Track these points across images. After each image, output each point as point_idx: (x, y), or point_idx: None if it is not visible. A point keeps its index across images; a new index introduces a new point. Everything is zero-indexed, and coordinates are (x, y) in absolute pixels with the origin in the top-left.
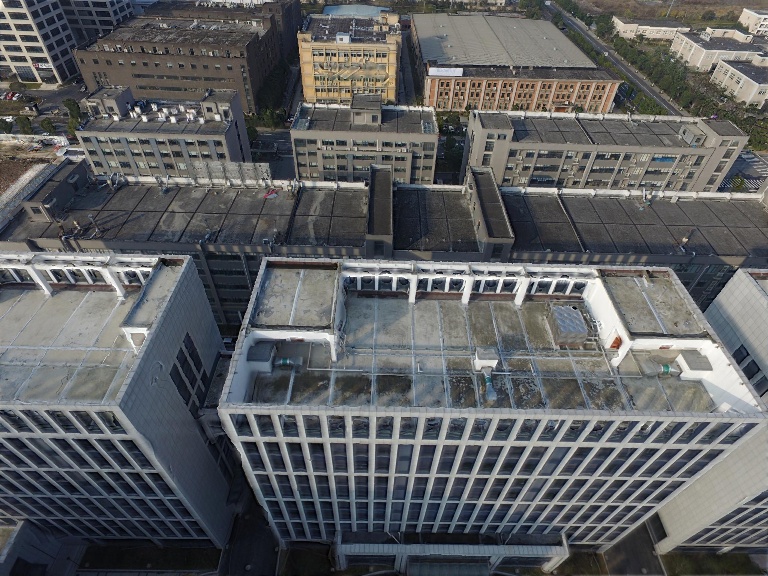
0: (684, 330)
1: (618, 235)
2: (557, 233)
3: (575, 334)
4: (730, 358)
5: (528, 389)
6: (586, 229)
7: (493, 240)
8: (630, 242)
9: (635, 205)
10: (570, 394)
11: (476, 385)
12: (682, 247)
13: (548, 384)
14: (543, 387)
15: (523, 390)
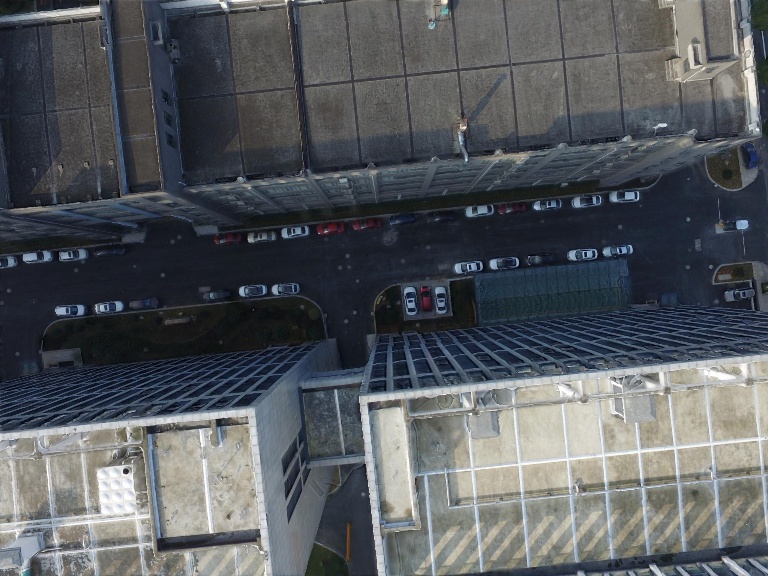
0: (237, 525)
1: (370, 111)
2: (270, 120)
3: (122, 512)
4: (269, 575)
5: (80, 567)
6: (320, 102)
7: (132, 196)
8: (385, 127)
9: (425, 14)
10: (127, 567)
11: (21, 569)
12: (461, 134)
13: (104, 557)
14: (97, 562)
15: (74, 569)
